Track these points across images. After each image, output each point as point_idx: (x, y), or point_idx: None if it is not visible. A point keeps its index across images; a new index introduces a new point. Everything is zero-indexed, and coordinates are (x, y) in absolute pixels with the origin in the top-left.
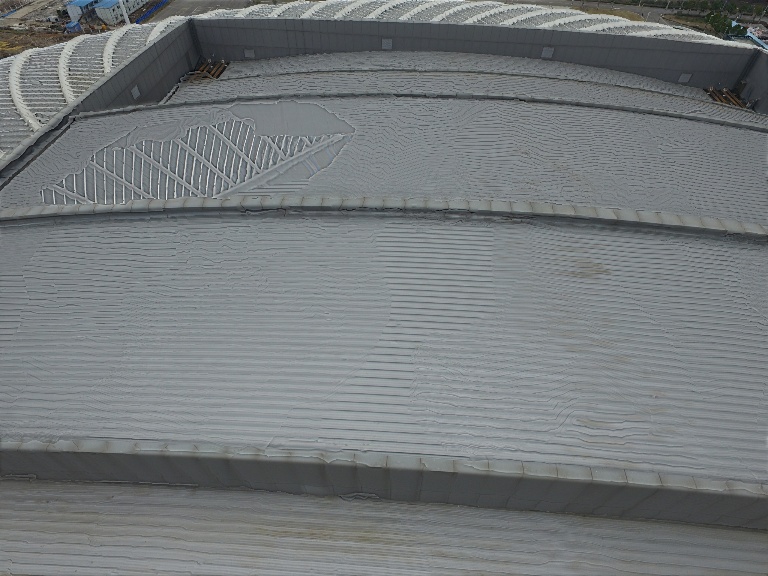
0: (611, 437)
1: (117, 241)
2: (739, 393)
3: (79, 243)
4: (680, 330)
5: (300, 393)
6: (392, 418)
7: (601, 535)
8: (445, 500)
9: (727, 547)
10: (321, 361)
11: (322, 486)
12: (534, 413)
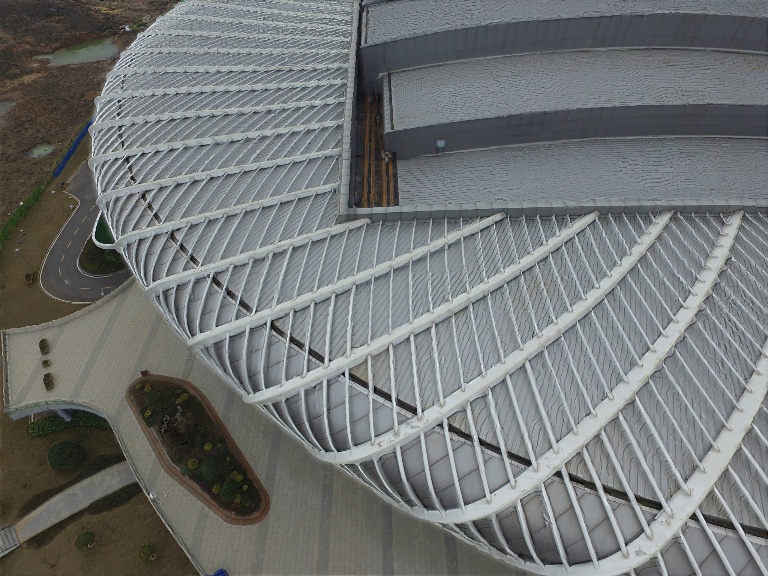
0: (689, 4)
1: (456, 1)
2: (725, 7)
3: (443, 0)
4: (702, 0)
5: (580, 12)
6: (619, 7)
7: (684, 52)
8: (632, 44)
9: (725, 55)
10: (581, 8)
11: (593, 38)
12: (663, 5)
